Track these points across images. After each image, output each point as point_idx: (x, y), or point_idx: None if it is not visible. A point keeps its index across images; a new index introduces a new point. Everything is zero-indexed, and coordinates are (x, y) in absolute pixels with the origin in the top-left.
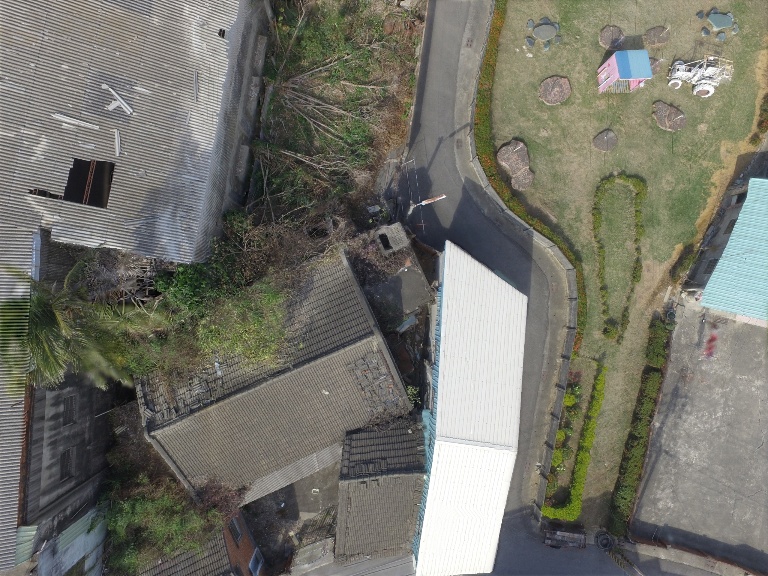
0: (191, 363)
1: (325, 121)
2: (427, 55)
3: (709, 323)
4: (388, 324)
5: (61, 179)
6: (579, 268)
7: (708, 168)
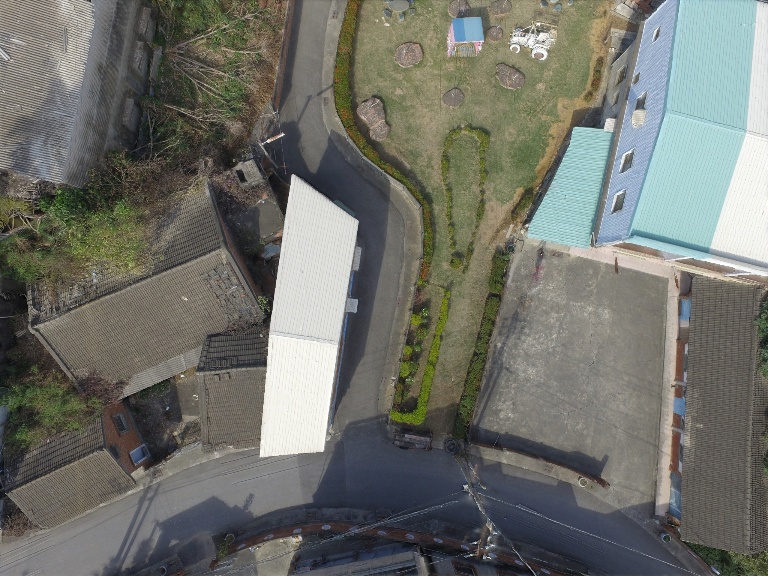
0: (73, 273)
1: (208, 82)
2: (298, 26)
3: (546, 256)
4: (245, 246)
5: None
6: (426, 206)
7: (546, 121)
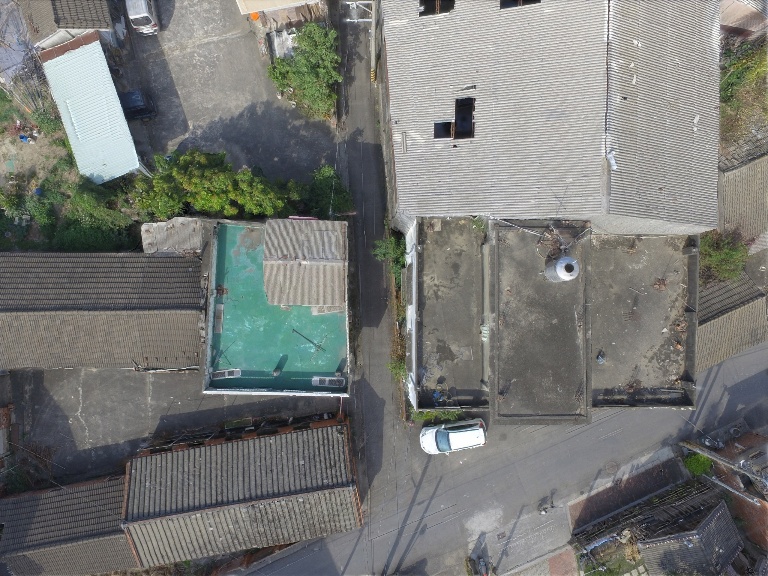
0: None
1: None
2: None
3: None
4: None
5: None
6: None
7: None
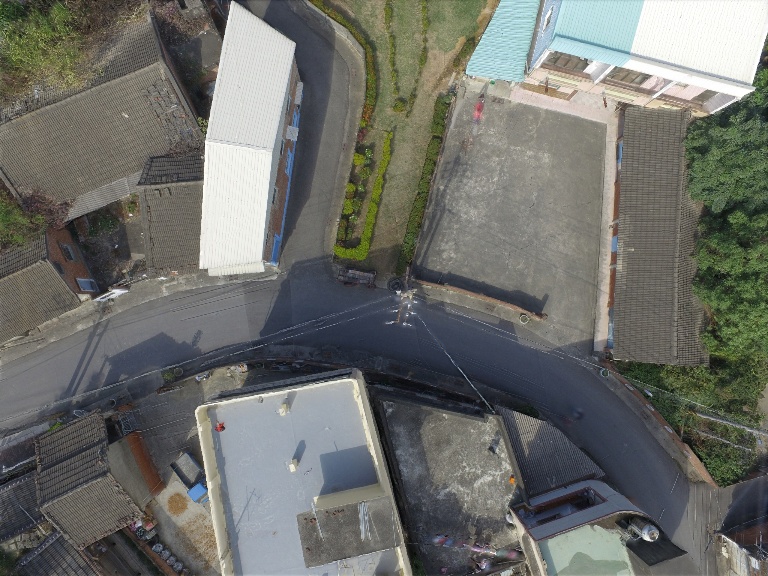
0: (15, 90)
1: None
2: None
3: (488, 103)
4: (187, 73)
5: None
6: (369, 50)
7: None
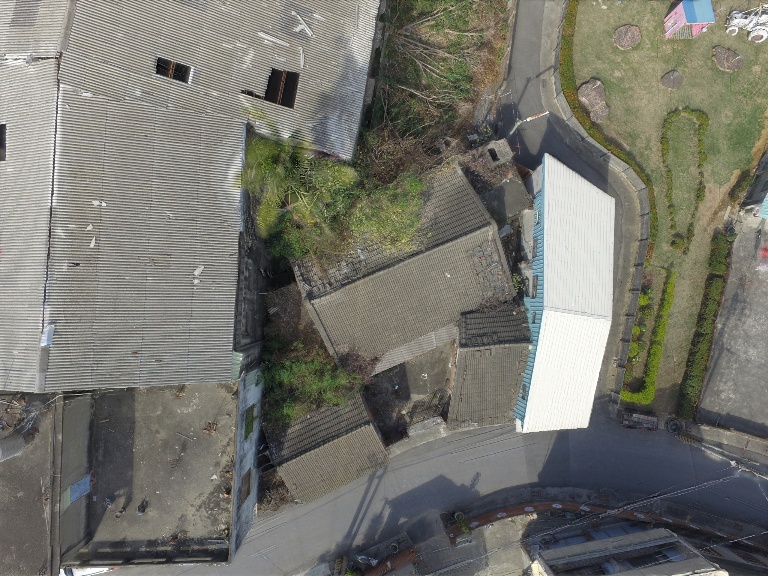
0: (338, 249)
1: (431, 63)
2: (517, 8)
3: (764, 238)
4: None
5: (263, 83)
6: (651, 187)
7: (762, 104)
